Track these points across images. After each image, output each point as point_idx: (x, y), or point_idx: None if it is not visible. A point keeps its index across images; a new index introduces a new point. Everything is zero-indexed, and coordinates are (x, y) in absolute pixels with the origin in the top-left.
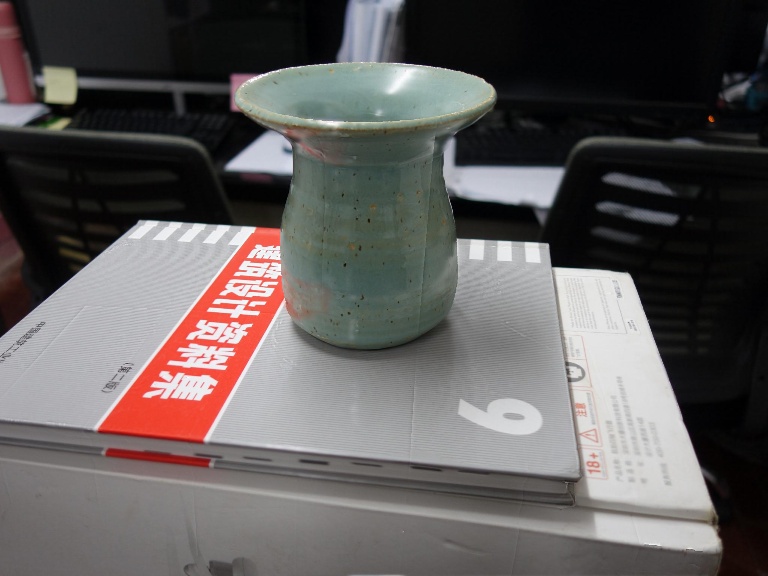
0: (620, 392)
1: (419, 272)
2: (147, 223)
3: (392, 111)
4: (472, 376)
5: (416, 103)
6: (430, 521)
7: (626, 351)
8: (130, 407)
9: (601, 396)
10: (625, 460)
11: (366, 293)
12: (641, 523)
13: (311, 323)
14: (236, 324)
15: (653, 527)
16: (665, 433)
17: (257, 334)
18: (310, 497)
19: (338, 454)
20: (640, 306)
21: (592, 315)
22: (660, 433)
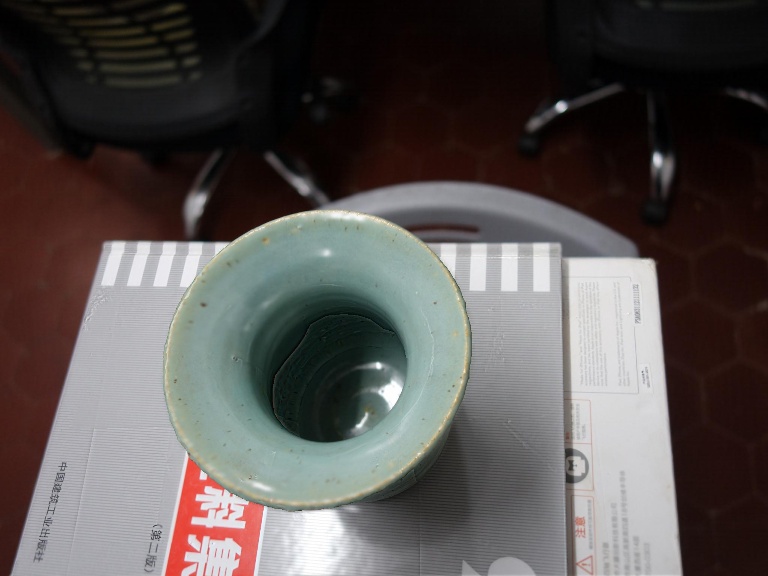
0: (621, 497)
1: None
2: (113, 248)
3: (351, 283)
4: (474, 522)
5: (378, 282)
6: None
7: (634, 425)
8: None
9: (601, 505)
10: None
11: None
12: None
13: None
14: None
15: None
16: (658, 559)
17: None
18: None
19: None
20: (659, 338)
21: (604, 360)
22: (653, 559)
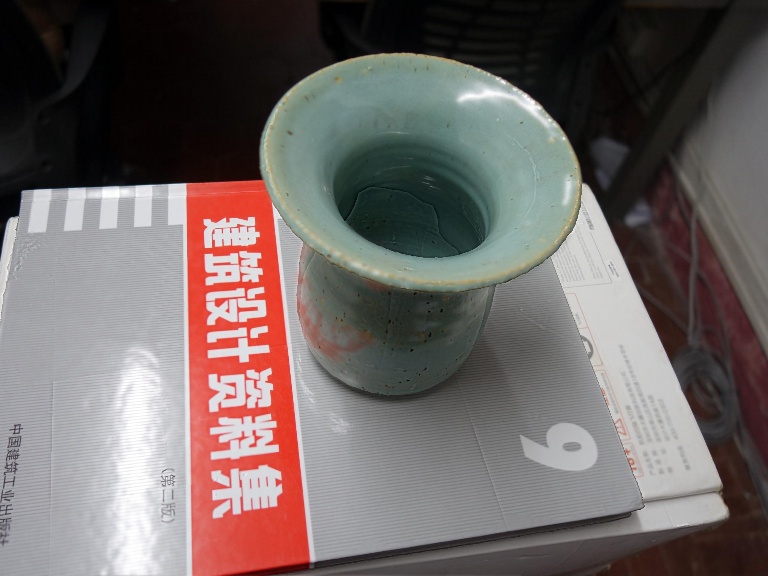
0: (627, 366)
1: (477, 329)
2: (36, 196)
3: (418, 128)
4: (519, 400)
5: (450, 121)
6: (512, 551)
7: (617, 308)
8: (208, 538)
9: (614, 375)
10: (651, 450)
11: (429, 365)
12: (670, 506)
13: (359, 384)
14: (253, 373)
15: (679, 507)
16: (673, 410)
17: (284, 385)
18: (405, 560)
19: (444, 541)
20: (613, 239)
21: (575, 260)
22: (670, 411)
